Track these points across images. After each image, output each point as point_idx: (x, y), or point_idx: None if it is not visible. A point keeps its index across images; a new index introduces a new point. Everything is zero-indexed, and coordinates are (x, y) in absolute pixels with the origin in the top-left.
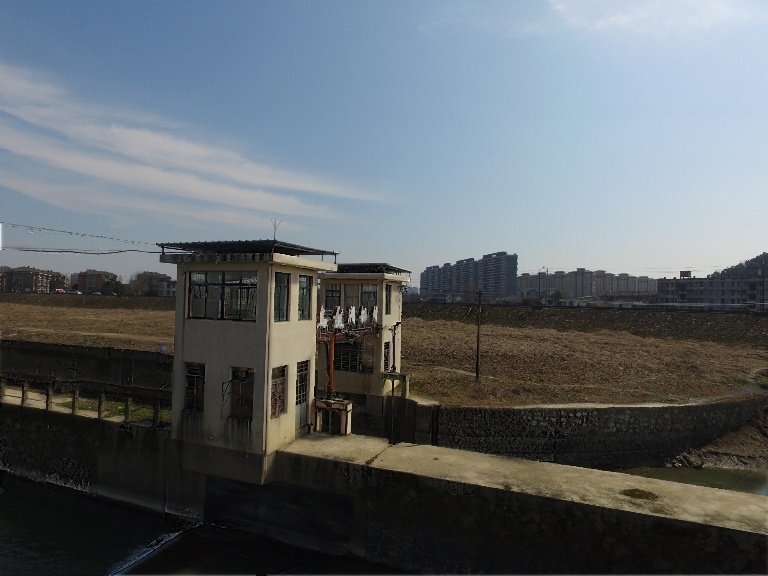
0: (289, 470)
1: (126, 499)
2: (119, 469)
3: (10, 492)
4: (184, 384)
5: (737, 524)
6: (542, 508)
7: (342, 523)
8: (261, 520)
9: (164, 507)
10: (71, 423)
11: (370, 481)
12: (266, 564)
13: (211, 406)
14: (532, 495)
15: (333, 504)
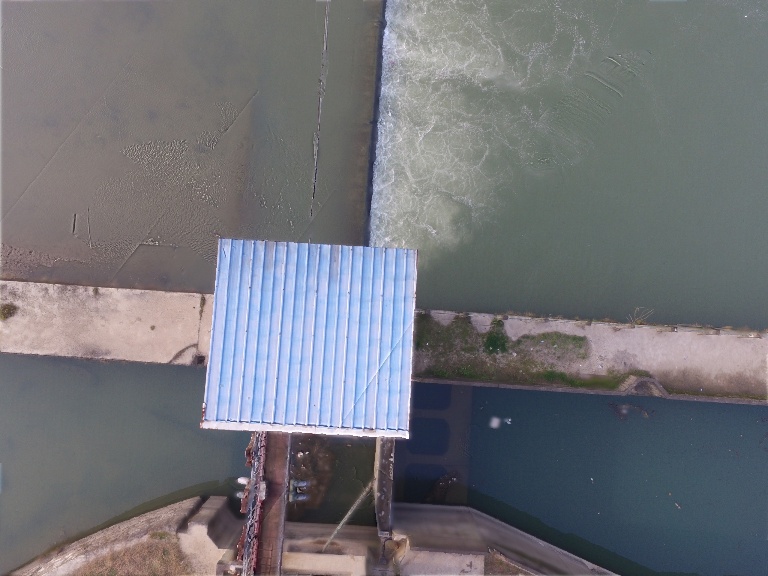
0: None
1: None
2: None
3: None
4: None
5: None
6: None
7: None
8: None
9: None
10: None
11: None
12: None
13: None
14: None
15: None
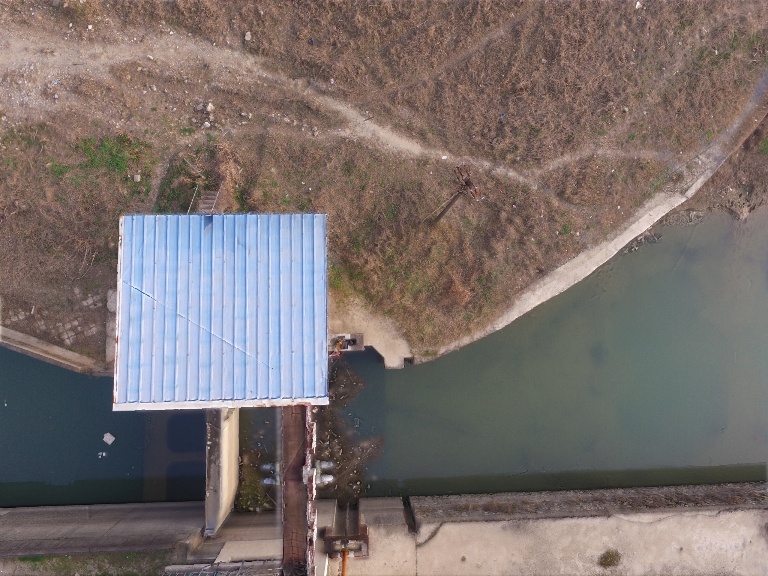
0: None
1: None
2: None
3: None
4: None
5: None
6: None
7: None
8: None
9: None
10: None
11: None
12: None
13: None
14: None
15: None
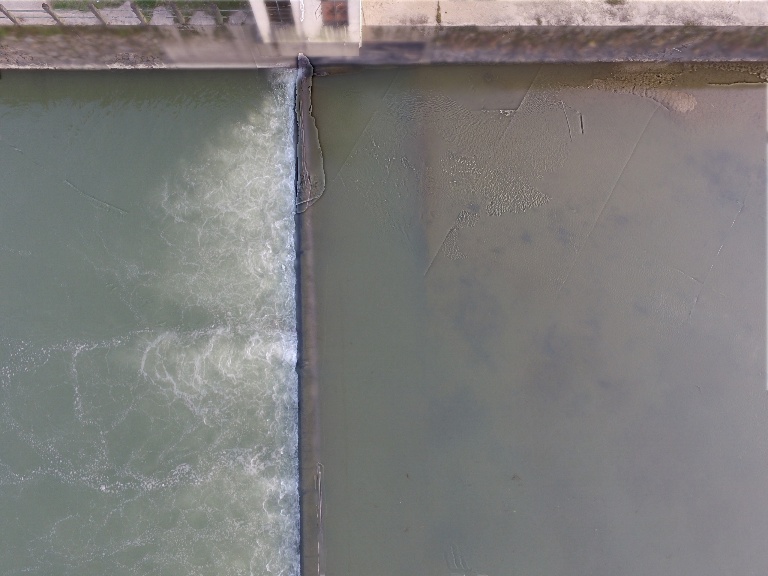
0: (372, 35)
1: (213, 67)
2: (194, 53)
3: (72, 81)
4: (264, 6)
5: (661, 18)
6: (558, 31)
7: (415, 54)
8: (349, 61)
9: (255, 66)
10: (109, 31)
11: (441, 33)
12: (372, 92)
13: (303, 21)
14: (555, 26)
15: (409, 47)
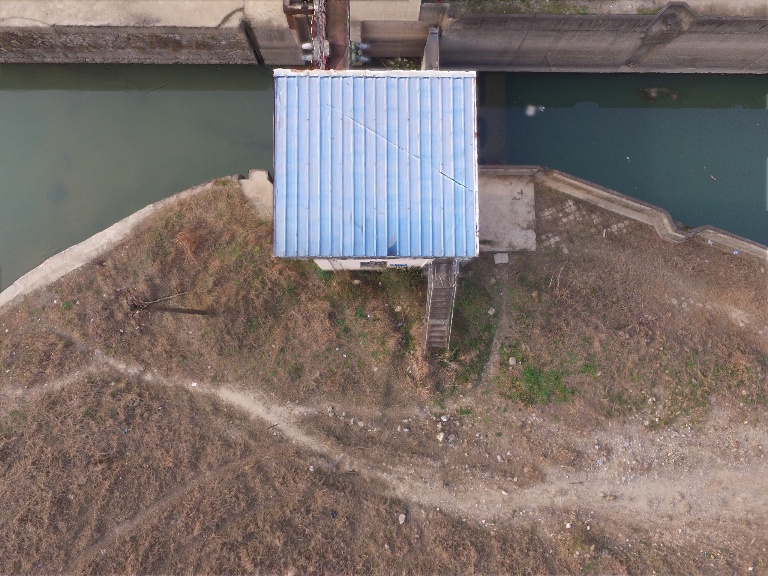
0: None
1: None
2: None
3: None
4: None
5: None
6: None
7: None
8: None
9: None
10: None
11: None
12: None
13: None
14: None
15: None
